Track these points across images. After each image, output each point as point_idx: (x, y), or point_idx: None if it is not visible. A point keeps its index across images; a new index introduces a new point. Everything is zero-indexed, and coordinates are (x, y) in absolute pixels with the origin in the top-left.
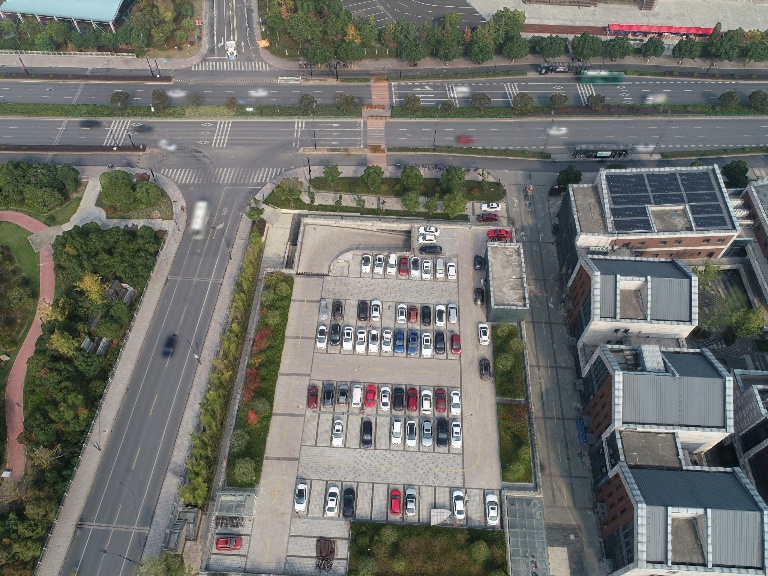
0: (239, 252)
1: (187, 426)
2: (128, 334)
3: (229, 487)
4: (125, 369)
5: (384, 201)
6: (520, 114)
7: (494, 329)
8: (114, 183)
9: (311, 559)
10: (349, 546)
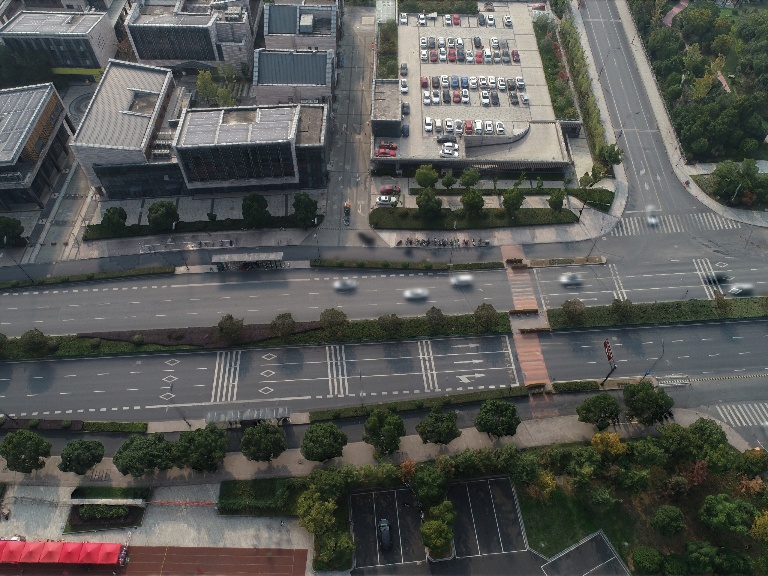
0: None
1: (588, 53)
2: None
3: None
4: (647, 77)
5: None
6: None
7: None
8: None
9: (496, 6)
10: None
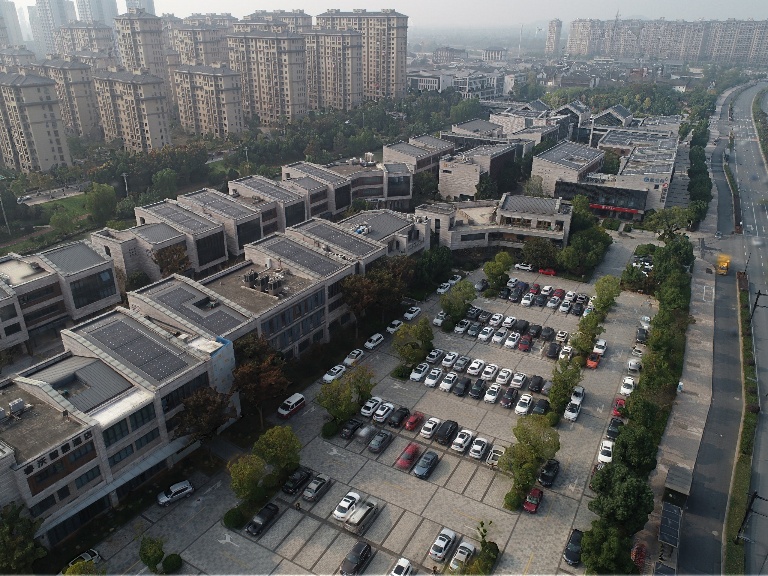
0: None
1: None
2: None
3: None
4: None
5: None
6: (766, 153)
7: None
8: None
9: None
10: None
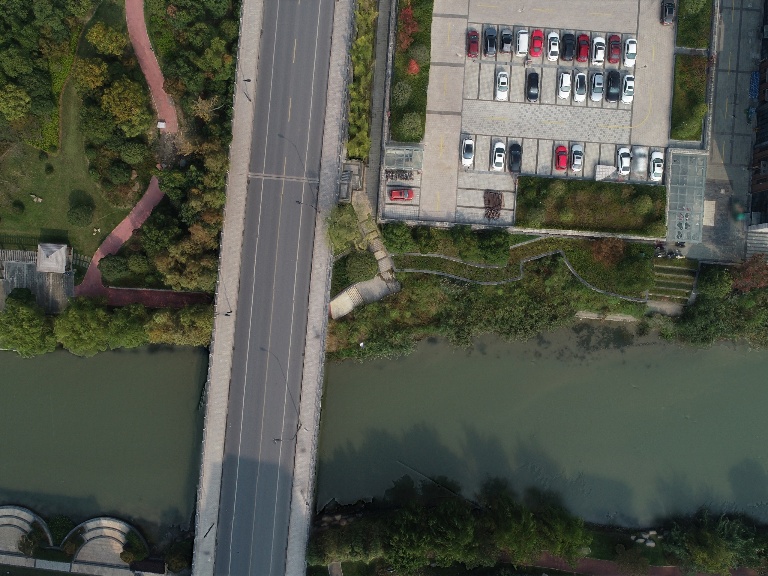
0: None
1: (336, 76)
2: None
3: (394, 141)
4: (253, 6)
5: None
6: None
7: None
8: None
9: (480, 209)
10: (516, 198)
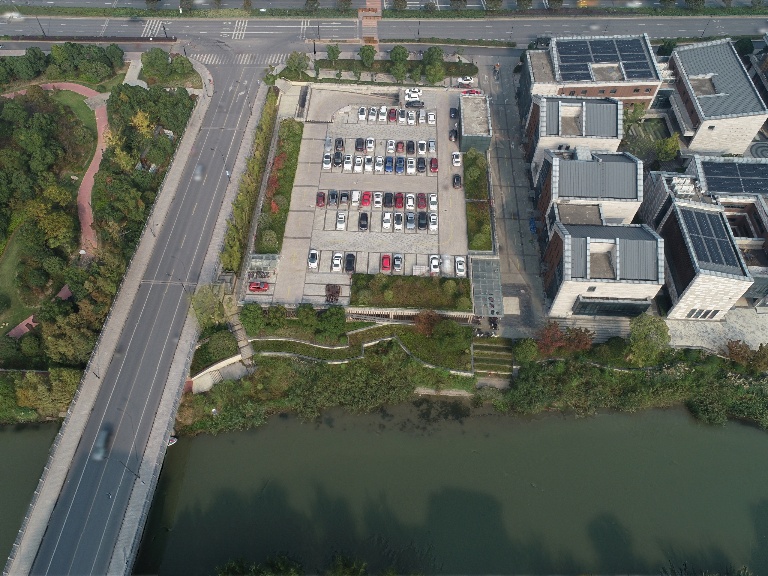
0: (258, 110)
1: (222, 221)
2: (171, 163)
3: None
4: (171, 186)
5: (377, 73)
6: (492, 15)
7: (465, 155)
8: (154, 58)
9: (322, 297)
10: (351, 288)
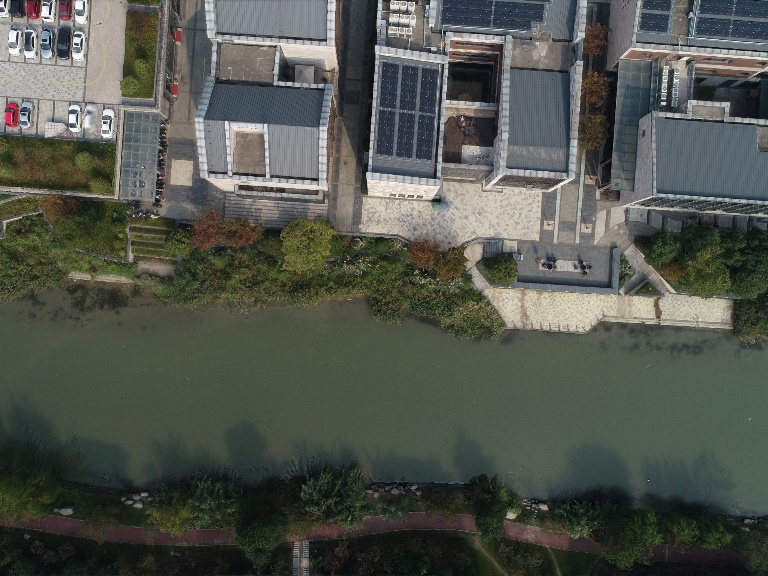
0: None
1: None
2: None
3: None
4: None
5: None
6: None
7: None
8: None
9: None
10: None
